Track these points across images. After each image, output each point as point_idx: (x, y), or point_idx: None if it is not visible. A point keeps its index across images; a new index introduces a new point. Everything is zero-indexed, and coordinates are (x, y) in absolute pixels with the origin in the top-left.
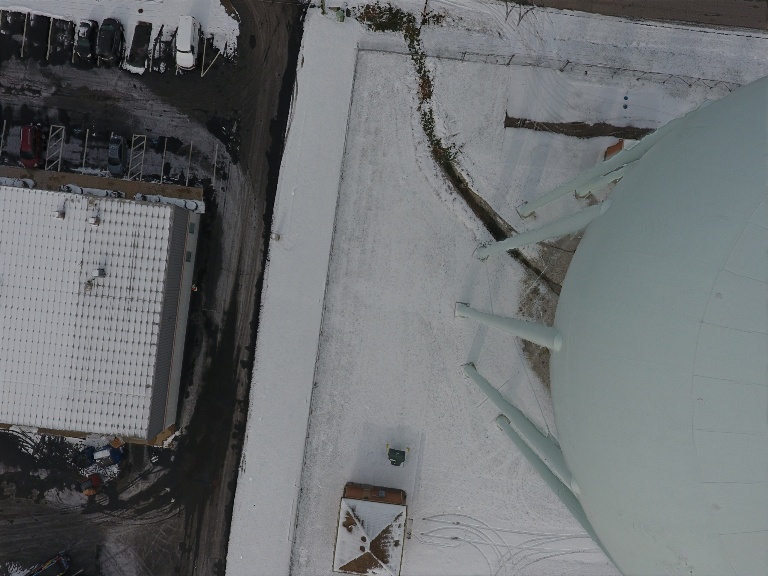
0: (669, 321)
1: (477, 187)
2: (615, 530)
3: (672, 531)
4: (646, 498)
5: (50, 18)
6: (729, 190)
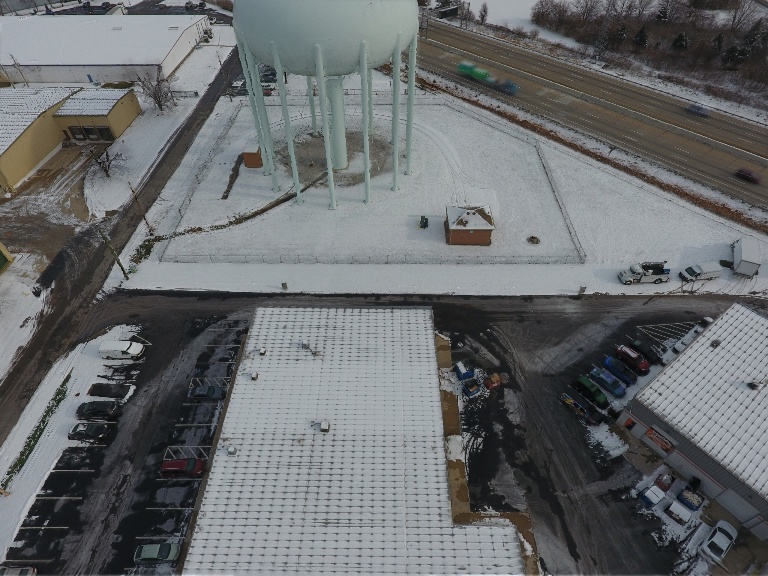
0: (304, 7)
1: (261, 206)
2: (370, 26)
3: (360, 6)
4: (354, 11)
5: (51, 473)
6: (269, 4)
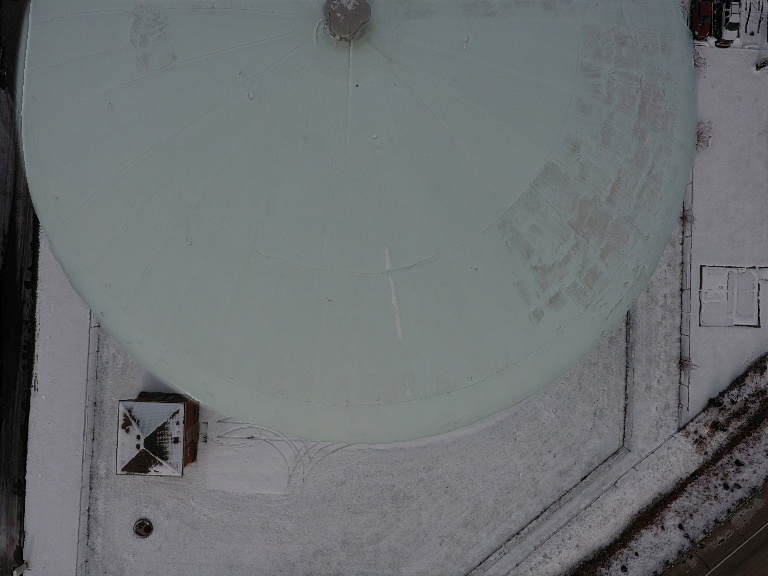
0: None
1: None
2: None
3: (50, 238)
4: (38, 215)
5: None
6: None
